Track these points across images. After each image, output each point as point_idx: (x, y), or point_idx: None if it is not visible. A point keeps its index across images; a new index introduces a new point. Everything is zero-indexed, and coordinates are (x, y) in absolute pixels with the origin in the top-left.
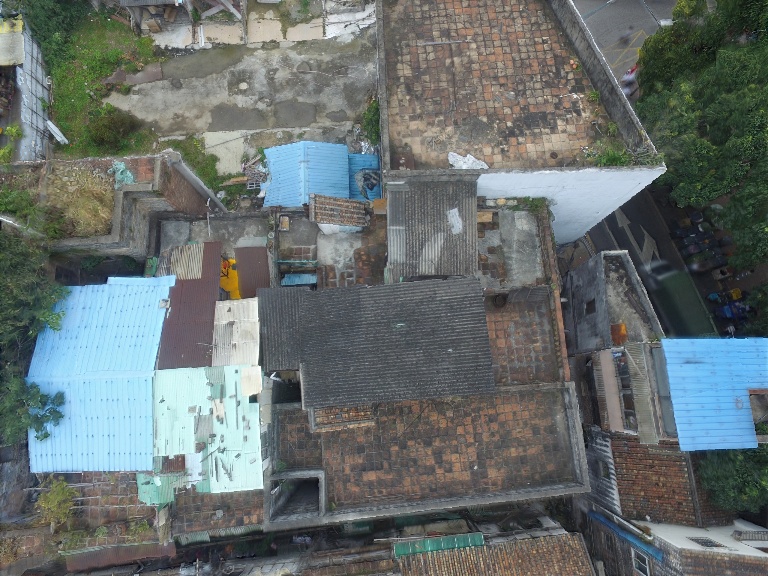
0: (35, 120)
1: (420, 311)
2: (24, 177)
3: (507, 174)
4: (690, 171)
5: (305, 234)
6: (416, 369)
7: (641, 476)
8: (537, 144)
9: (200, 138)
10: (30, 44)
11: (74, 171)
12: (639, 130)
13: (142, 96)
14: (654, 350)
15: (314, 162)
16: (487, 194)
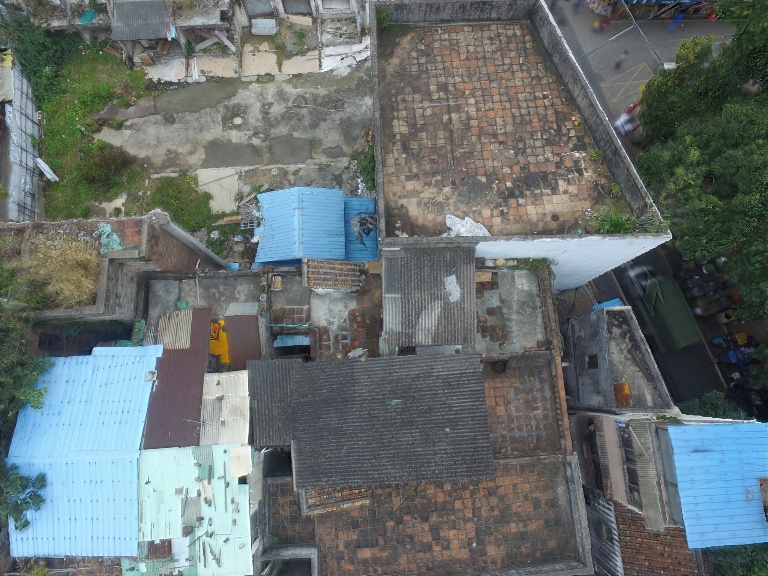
0: (25, 158)
1: (416, 387)
2: (6, 241)
3: (507, 242)
4: (695, 225)
5: (298, 294)
6: (412, 450)
7: (645, 545)
8: (538, 206)
9: (193, 175)
10: (20, 79)
11: (58, 234)
12: (643, 195)
13: (134, 131)
14: (660, 431)
15: (309, 209)
16: (486, 256)
